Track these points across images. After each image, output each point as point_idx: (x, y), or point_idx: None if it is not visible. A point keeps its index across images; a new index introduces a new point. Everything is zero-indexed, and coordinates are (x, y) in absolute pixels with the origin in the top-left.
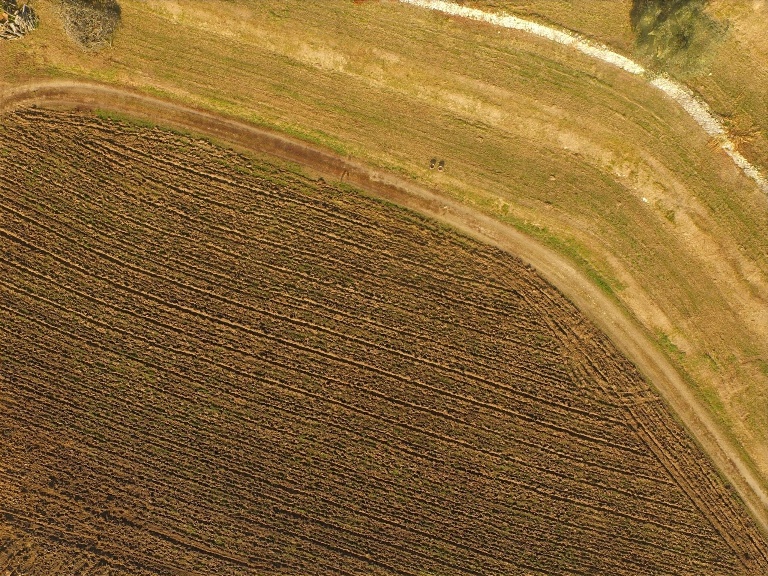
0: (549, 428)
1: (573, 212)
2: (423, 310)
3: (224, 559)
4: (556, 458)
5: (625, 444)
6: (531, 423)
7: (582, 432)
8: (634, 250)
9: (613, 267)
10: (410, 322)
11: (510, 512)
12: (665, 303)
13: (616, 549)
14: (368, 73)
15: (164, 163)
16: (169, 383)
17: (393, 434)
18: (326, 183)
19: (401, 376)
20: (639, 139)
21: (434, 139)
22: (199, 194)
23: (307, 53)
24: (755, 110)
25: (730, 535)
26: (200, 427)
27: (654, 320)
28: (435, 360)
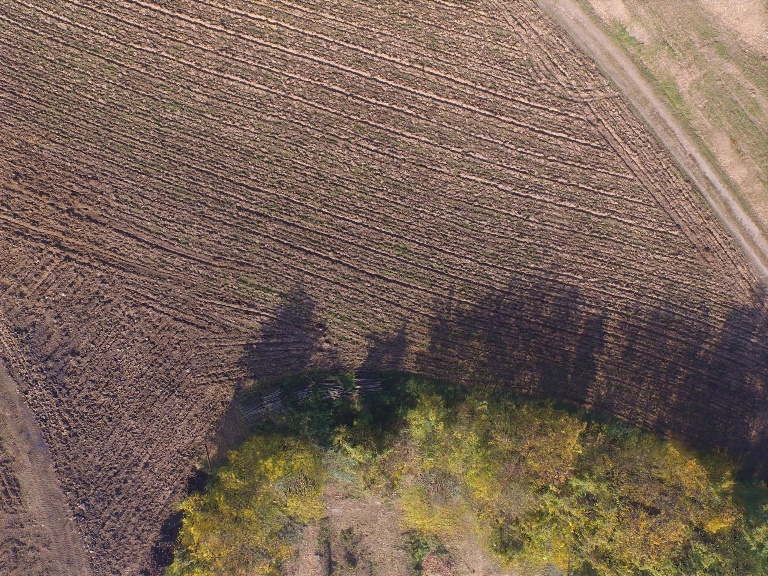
0: (509, 124)
1: None
2: (382, 5)
3: (188, 258)
4: (517, 155)
5: (585, 139)
6: (491, 119)
7: (542, 127)
8: None
9: None
10: (369, 17)
11: (472, 210)
12: None
13: (577, 245)
14: None
15: None
16: (130, 80)
17: (354, 131)
18: None
19: (361, 72)
20: None
21: None
22: None
23: None
24: None
25: (691, 229)
26: (162, 124)
27: (612, 11)
28: (395, 56)
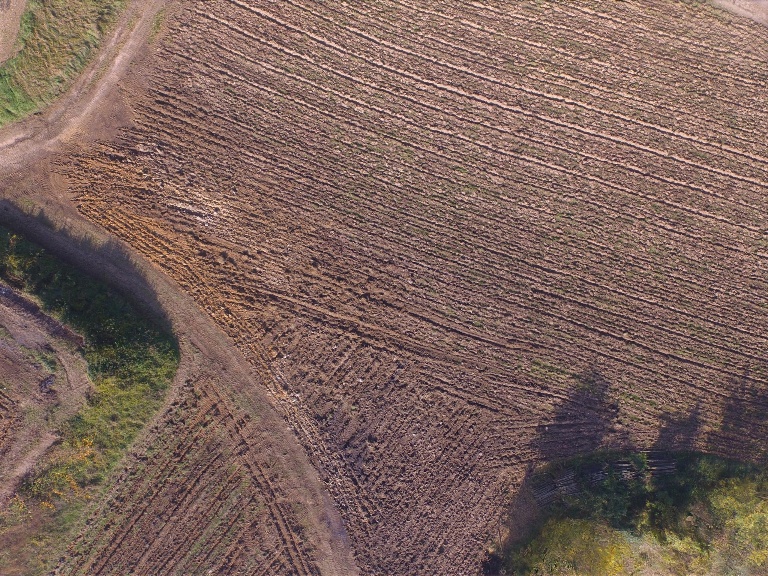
0: None
1: None
2: (680, 83)
3: (483, 341)
4: None
5: None
6: None
7: None
8: None
9: None
10: (667, 96)
11: (767, 288)
12: None
13: None
14: None
15: None
16: (427, 162)
17: (650, 211)
18: None
19: (658, 151)
20: None
21: None
22: None
23: None
24: None
25: None
26: (458, 207)
27: None
28: (692, 134)
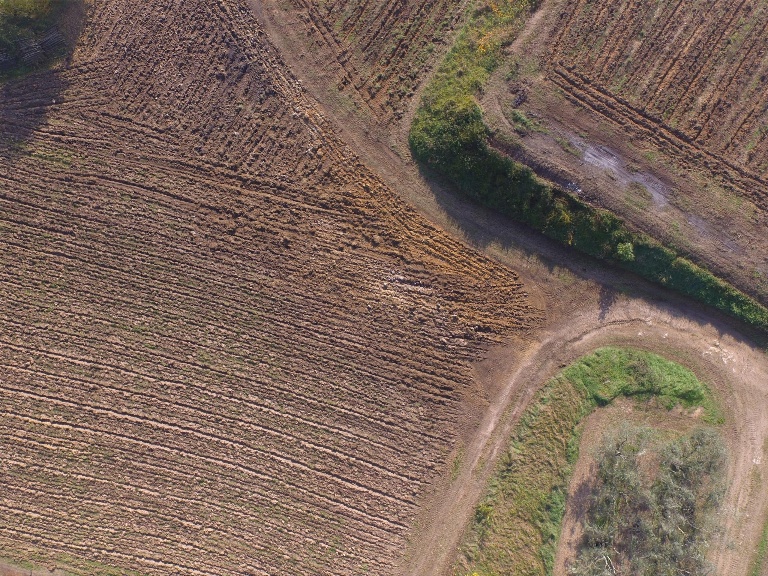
0: None
1: None
2: None
3: (120, 181)
4: None
5: None
6: None
7: None
8: None
9: None
10: None
11: None
12: None
13: None
14: None
15: (209, 572)
16: (184, 351)
17: None
18: (47, 568)
19: None
20: None
21: None
22: (171, 544)
23: None
24: None
25: None
26: (151, 310)
27: None
28: None
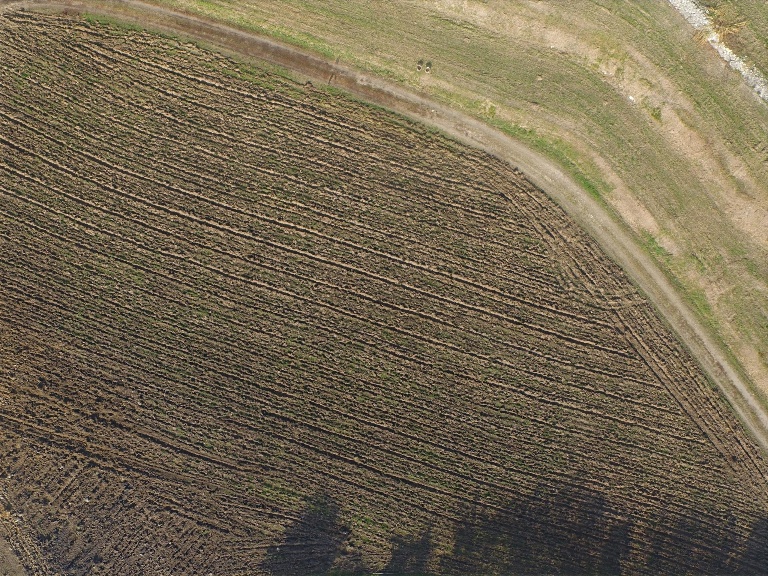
0: (537, 331)
1: (560, 112)
2: (411, 213)
3: (213, 462)
4: (544, 361)
5: (613, 347)
6: (519, 326)
7: (570, 335)
8: (621, 150)
9: (600, 168)
10: (398, 225)
11: (498, 415)
12: (652, 203)
13: (604, 452)
14: None
15: (152, 66)
16: (158, 285)
17: (381, 337)
18: (314, 87)
19: (389, 279)
20: (625, 34)
21: (421, 40)
22: (187, 97)
23: None
24: (740, 0)
25: (717, 438)
26: (189, 330)
27: (641, 222)
28: (423, 263)
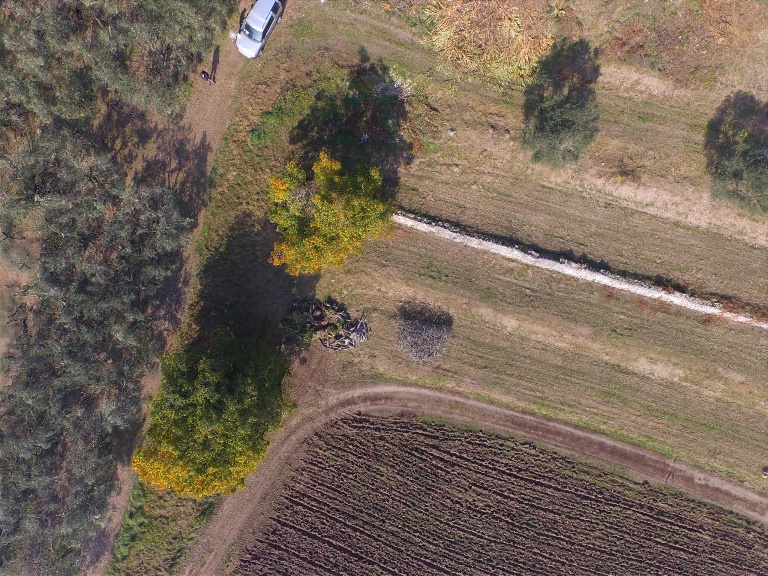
0: None
1: None
2: None
3: None
4: None
5: None
6: None
7: None
8: None
9: None
10: None
11: None
12: None
13: None
14: (705, 385)
15: (489, 469)
16: None
17: None
18: (651, 486)
19: None
20: None
21: (767, 447)
22: (525, 500)
23: (643, 365)
24: None
25: None
26: None
27: None
28: None
